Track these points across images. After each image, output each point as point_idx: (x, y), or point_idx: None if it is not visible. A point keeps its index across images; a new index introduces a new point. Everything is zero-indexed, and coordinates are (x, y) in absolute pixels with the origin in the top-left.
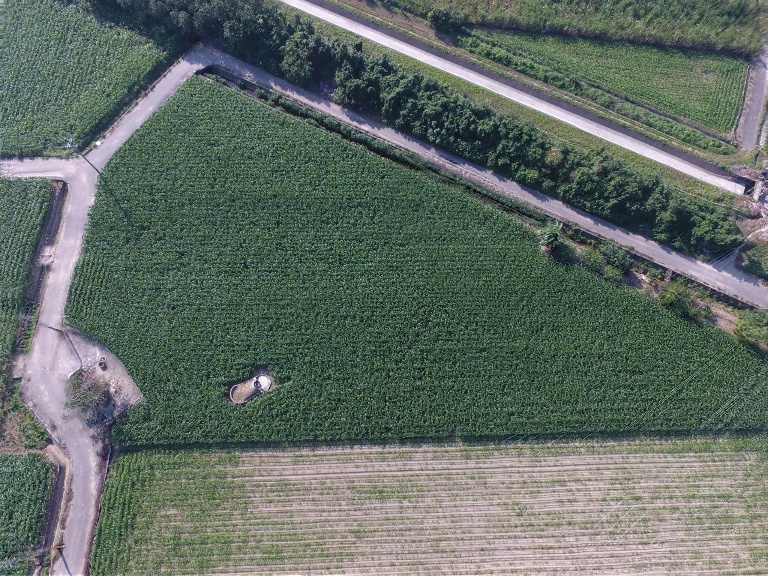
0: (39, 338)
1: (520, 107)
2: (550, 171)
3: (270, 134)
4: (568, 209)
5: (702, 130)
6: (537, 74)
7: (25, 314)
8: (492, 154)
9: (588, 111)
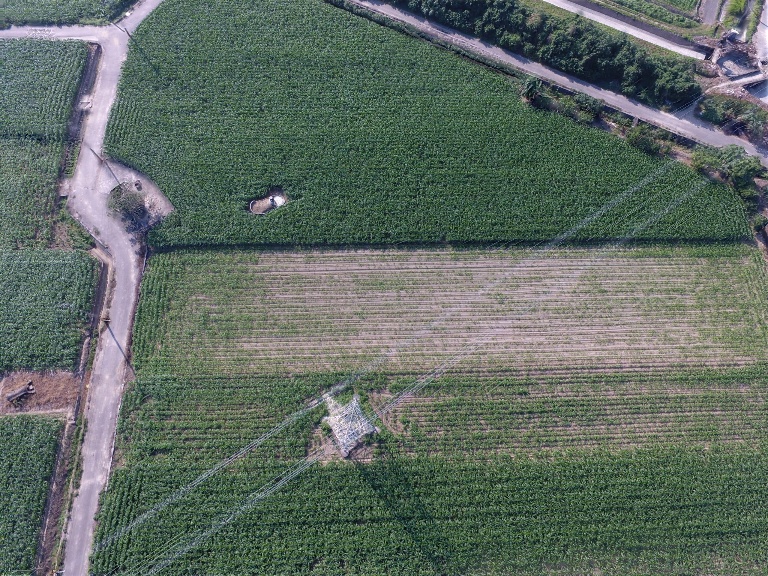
0: (82, 165)
1: None
2: (530, 35)
3: (281, 7)
4: (547, 70)
5: (668, 8)
6: None
7: (68, 147)
8: (479, 21)
9: None
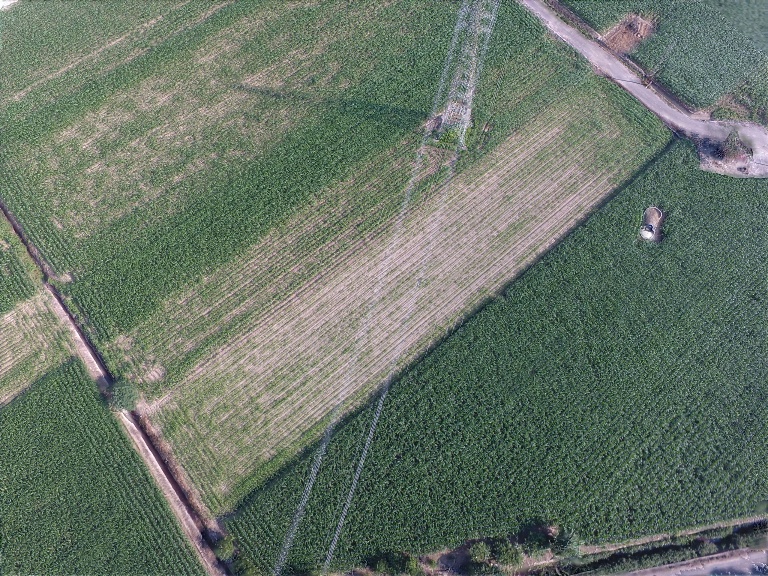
0: None
1: None
2: None
3: None
4: None
5: None
6: None
7: None
8: None
9: None
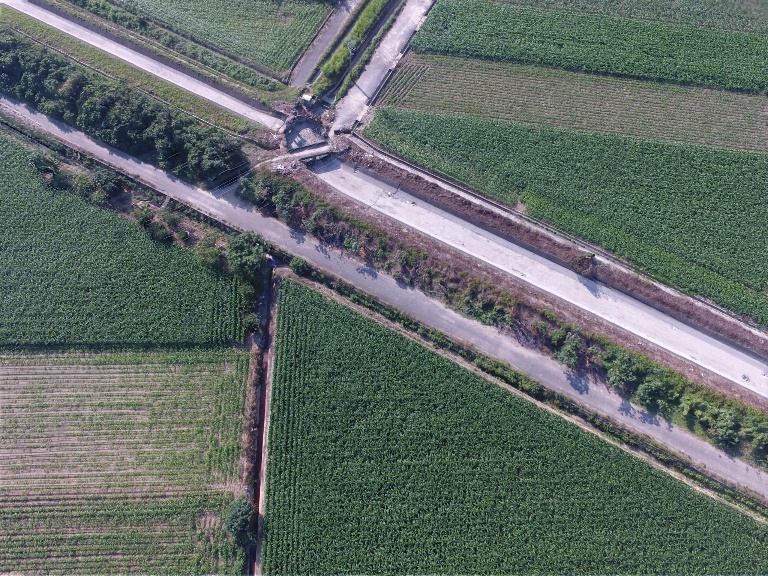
0: None
1: (79, 45)
2: (68, 102)
3: None
4: (88, 140)
5: (257, 68)
6: (107, 14)
7: None
8: (16, 86)
9: (149, 50)
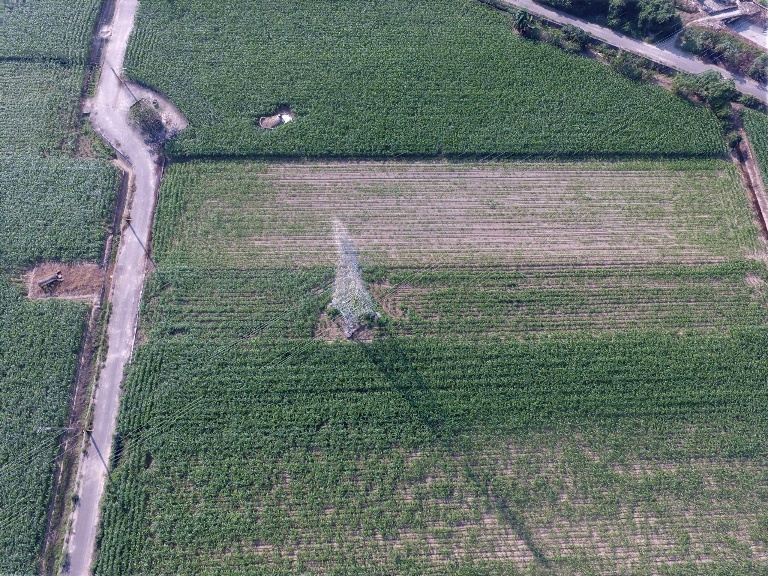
0: (103, 86)
1: None
2: None
3: None
4: (537, 5)
5: None
6: None
7: (90, 71)
8: None
9: None
